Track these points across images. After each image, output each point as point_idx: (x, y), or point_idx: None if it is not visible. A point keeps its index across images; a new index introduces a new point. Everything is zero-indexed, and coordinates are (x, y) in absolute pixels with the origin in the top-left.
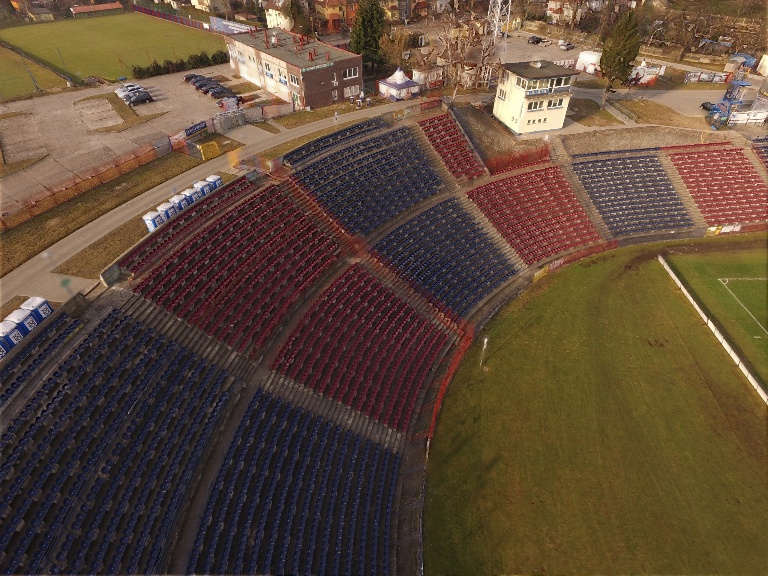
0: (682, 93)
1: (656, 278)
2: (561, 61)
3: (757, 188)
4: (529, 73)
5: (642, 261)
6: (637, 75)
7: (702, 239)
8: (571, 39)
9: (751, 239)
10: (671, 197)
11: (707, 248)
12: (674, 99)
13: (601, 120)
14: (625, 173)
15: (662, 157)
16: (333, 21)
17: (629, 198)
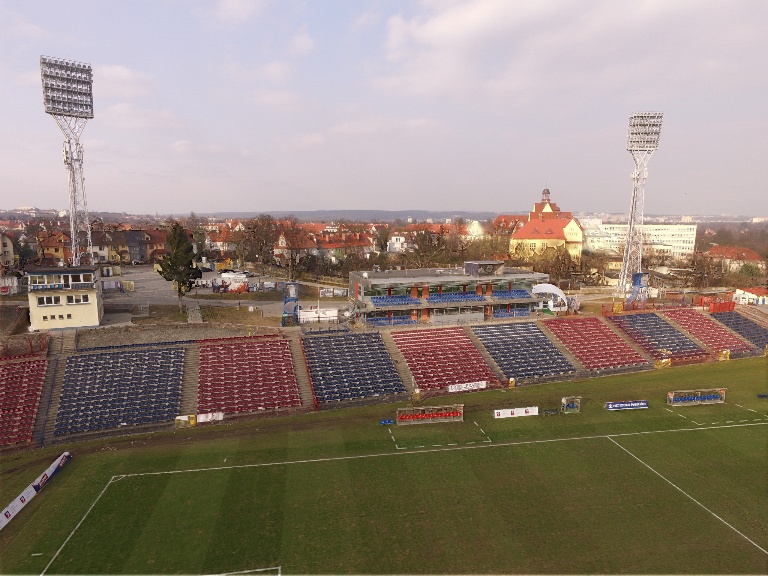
0: (300, 303)
1: (25, 482)
2: (202, 280)
3: (282, 375)
4: (37, 269)
5: (44, 462)
6: (223, 282)
7: (170, 431)
8: (276, 274)
9: (231, 428)
10: (172, 388)
11: (160, 441)
12: (283, 306)
13: (166, 320)
14: (132, 365)
15: (193, 349)
16: (43, 259)
17: (115, 390)
